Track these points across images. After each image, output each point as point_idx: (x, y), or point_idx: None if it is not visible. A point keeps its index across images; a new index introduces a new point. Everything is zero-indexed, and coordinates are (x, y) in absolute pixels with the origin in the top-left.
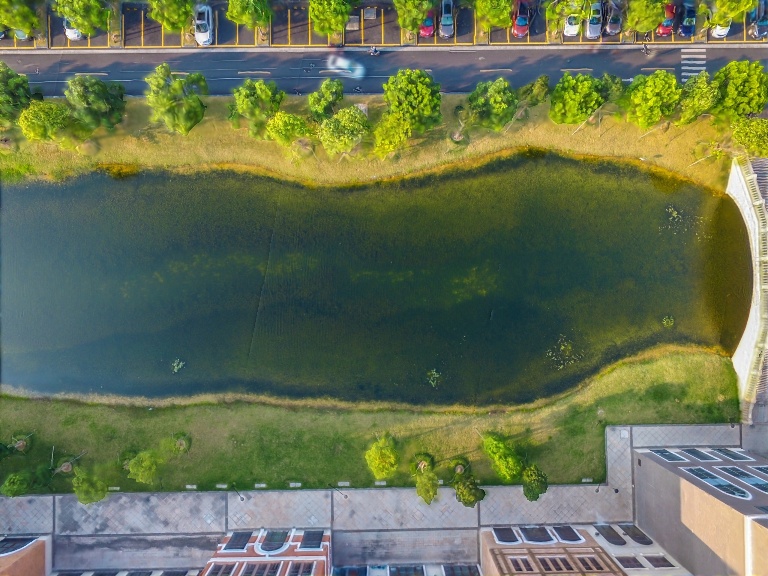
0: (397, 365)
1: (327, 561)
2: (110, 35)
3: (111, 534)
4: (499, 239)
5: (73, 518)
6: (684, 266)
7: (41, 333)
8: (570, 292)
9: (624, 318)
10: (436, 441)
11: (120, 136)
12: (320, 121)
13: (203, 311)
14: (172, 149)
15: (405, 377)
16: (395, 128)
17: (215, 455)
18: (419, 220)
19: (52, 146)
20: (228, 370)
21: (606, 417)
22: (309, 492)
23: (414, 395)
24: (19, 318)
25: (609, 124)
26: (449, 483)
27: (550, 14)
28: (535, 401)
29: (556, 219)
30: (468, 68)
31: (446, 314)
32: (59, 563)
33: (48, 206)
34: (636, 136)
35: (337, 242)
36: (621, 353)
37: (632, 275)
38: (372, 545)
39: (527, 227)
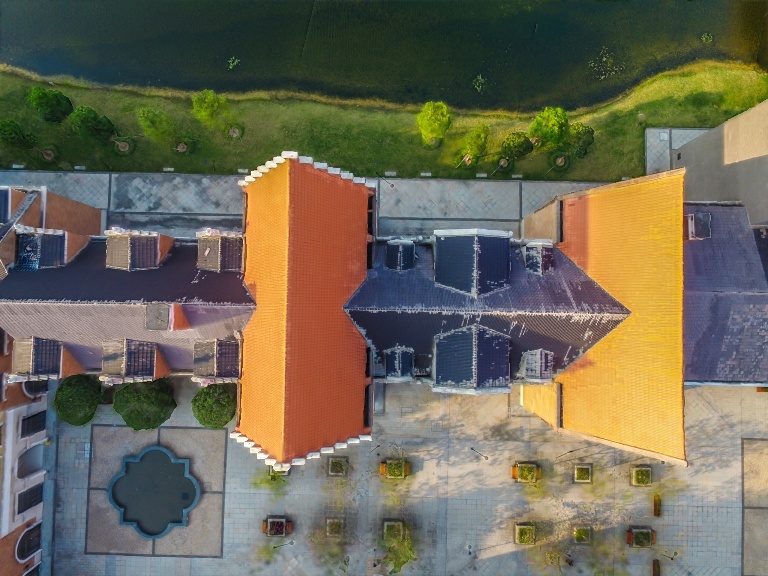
0: (444, 70)
1: None
2: None
3: (164, 213)
4: None
5: (128, 196)
6: None
7: (103, 29)
8: (612, 9)
9: (664, 35)
10: None
11: None
12: None
13: (259, 13)
14: None
15: (451, 82)
16: None
17: (267, 142)
18: None
19: None
20: (281, 69)
21: (646, 120)
22: None
23: (460, 99)
24: (82, 14)
25: None
26: (493, 176)
27: None
28: (577, 109)
29: None
30: None
31: (492, 26)
32: None
33: None
34: None
35: None
36: (661, 67)
37: None
38: (416, 233)
39: None
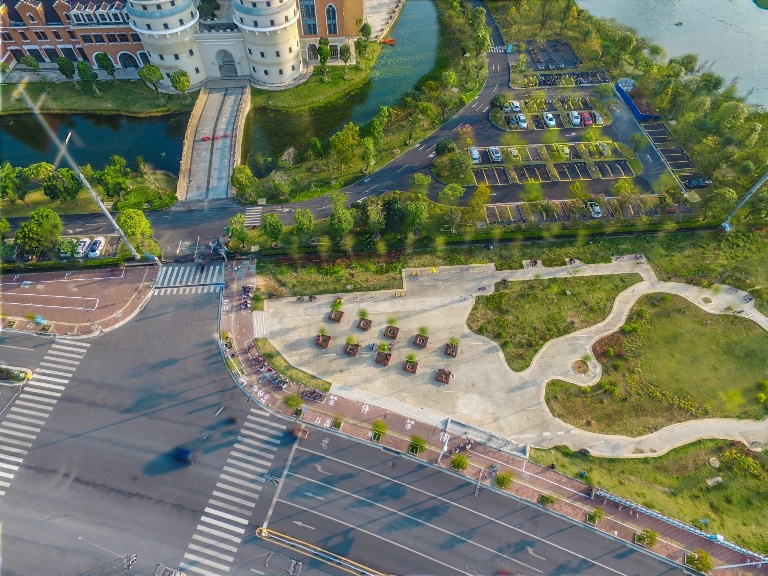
0: None
1: None
2: None
3: None
4: None
5: None
6: None
7: (81, 132)
8: None
9: None
10: None
11: None
12: None
13: None
14: None
15: None
16: None
17: (3, 94)
18: None
19: None
20: None
21: None
22: None
23: None
24: (91, 137)
25: None
26: None
27: None
28: None
29: None
30: None
31: None
32: None
33: None
34: None
35: None
36: None
37: None
38: None
39: None
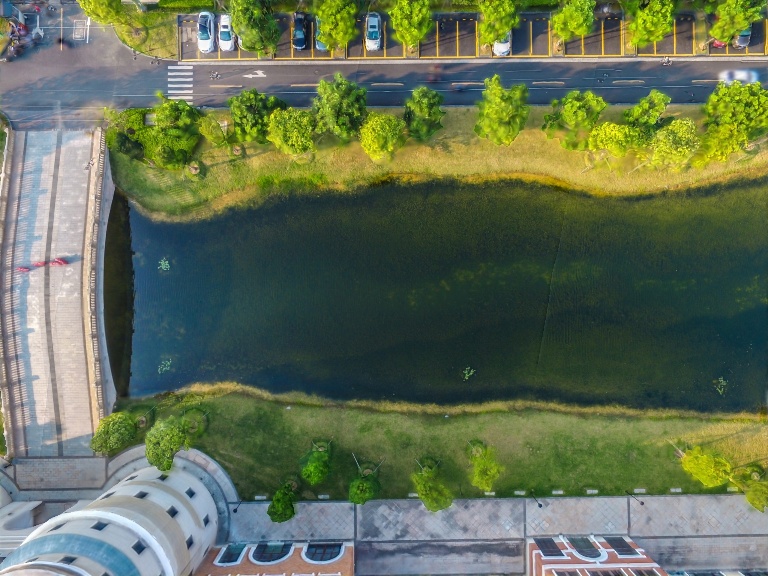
0: (684, 373)
1: None
2: (407, 45)
3: (411, 540)
4: None
5: (374, 524)
6: None
7: (332, 341)
8: None
9: None
10: (728, 448)
11: (415, 146)
12: (647, 132)
13: (492, 319)
14: (465, 158)
15: (692, 385)
16: (728, 139)
17: (512, 462)
18: (704, 229)
19: (348, 156)
20: (517, 378)
21: None
22: (606, 499)
23: (701, 403)
24: (310, 326)
25: None
26: None
27: None
28: None
29: None
30: (759, 78)
31: (729, 322)
32: (361, 569)
33: (339, 215)
34: None
35: (623, 251)
36: None
37: None
38: (669, 551)
39: None
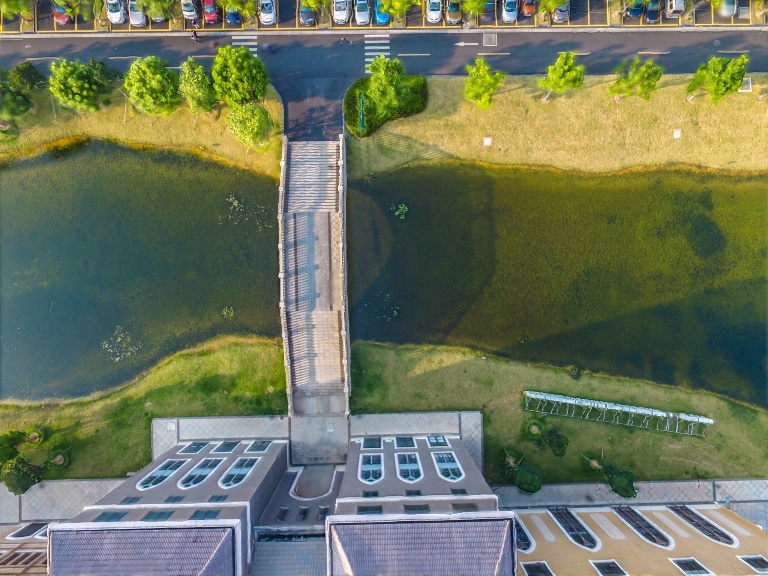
0: None
1: None
2: None
3: None
4: (59, 230)
5: None
6: (248, 256)
7: None
8: (131, 283)
9: (185, 309)
10: None
11: None
12: None
13: None
14: None
15: None
16: None
17: None
18: None
19: None
20: None
21: (153, 410)
22: None
23: None
24: None
25: None
26: None
27: (57, 0)
28: (91, 394)
29: (117, 209)
30: (14, 56)
31: (5, 306)
32: None
33: None
34: (190, 124)
35: None
36: (180, 345)
37: (195, 265)
38: None
39: (87, 217)
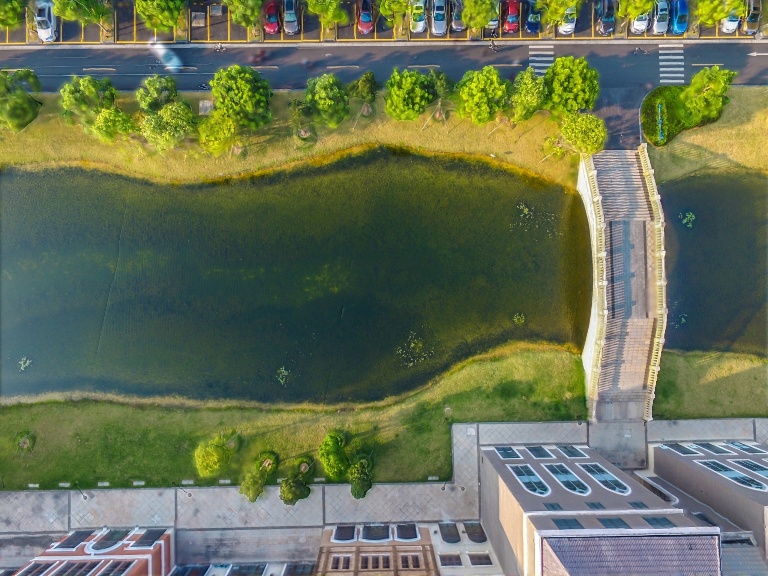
0: (246, 363)
1: (153, 560)
2: None
3: None
4: (350, 236)
5: None
6: (536, 263)
7: None
8: (422, 289)
9: (475, 315)
10: (282, 439)
11: None
12: None
13: (51, 309)
14: (18, 146)
15: (254, 375)
16: (220, 124)
17: (58, 453)
18: (269, 217)
19: None
20: (76, 368)
21: (453, 415)
22: (153, 490)
23: (263, 393)
24: None
25: (457, 121)
26: None
27: (383, 10)
28: (385, 399)
29: (407, 216)
30: (315, 65)
31: (297, 311)
32: None
33: None
34: (485, 133)
35: (186, 239)
36: (472, 350)
37: (484, 272)
38: (216, 544)
39: (378, 224)
